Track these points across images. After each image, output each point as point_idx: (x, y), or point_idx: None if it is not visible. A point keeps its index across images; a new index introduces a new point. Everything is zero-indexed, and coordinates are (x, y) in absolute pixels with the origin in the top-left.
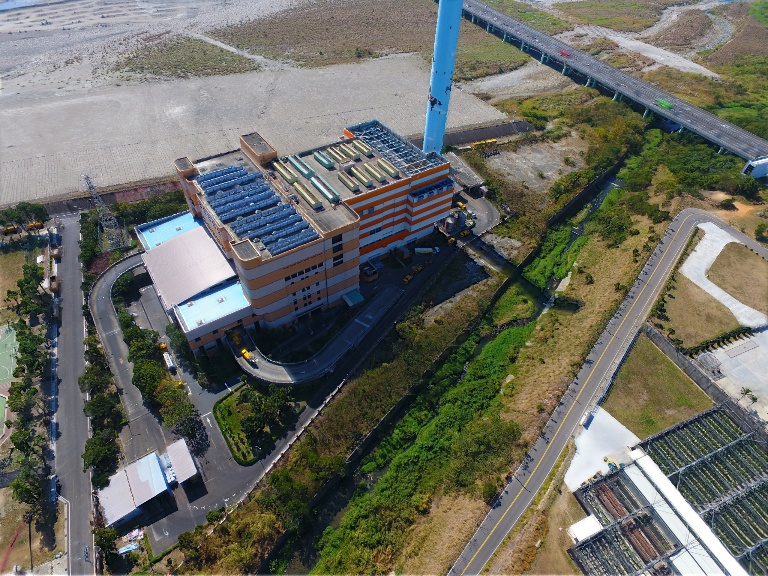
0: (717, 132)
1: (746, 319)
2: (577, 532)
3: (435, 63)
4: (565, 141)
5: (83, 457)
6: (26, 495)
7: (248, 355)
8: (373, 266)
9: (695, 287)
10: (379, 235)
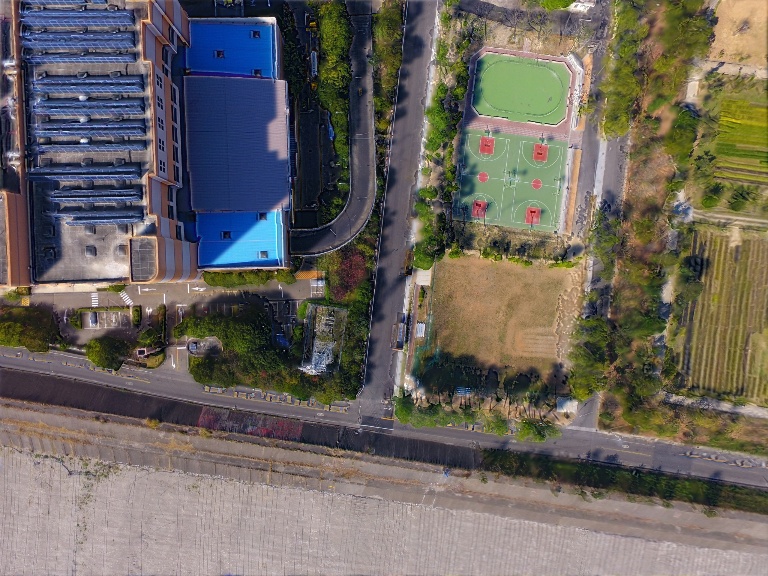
0: None
1: None
2: None
3: None
4: None
5: None
6: None
7: None
8: None
9: None
10: None
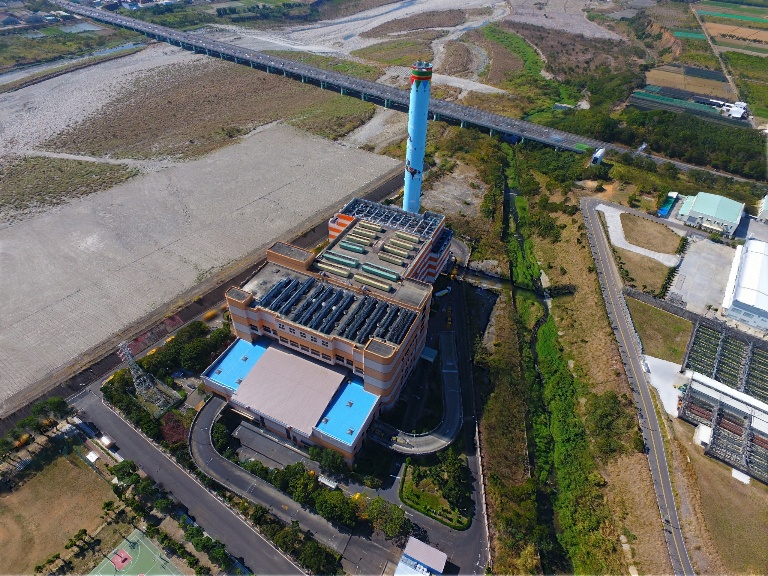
0: (547, 136)
1: (667, 262)
2: (703, 439)
3: (413, 142)
4: (458, 170)
5: None
6: None
7: (401, 440)
8: None
9: (629, 252)
10: None
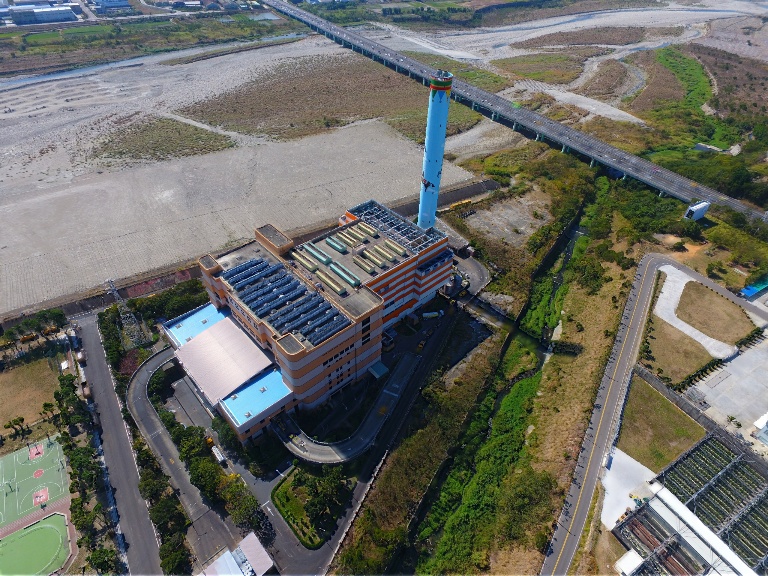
0: (655, 178)
1: (716, 351)
2: (623, 567)
3: (427, 153)
4: (530, 195)
5: (162, 566)
6: None
7: (296, 440)
8: (389, 336)
9: (669, 326)
10: (392, 307)
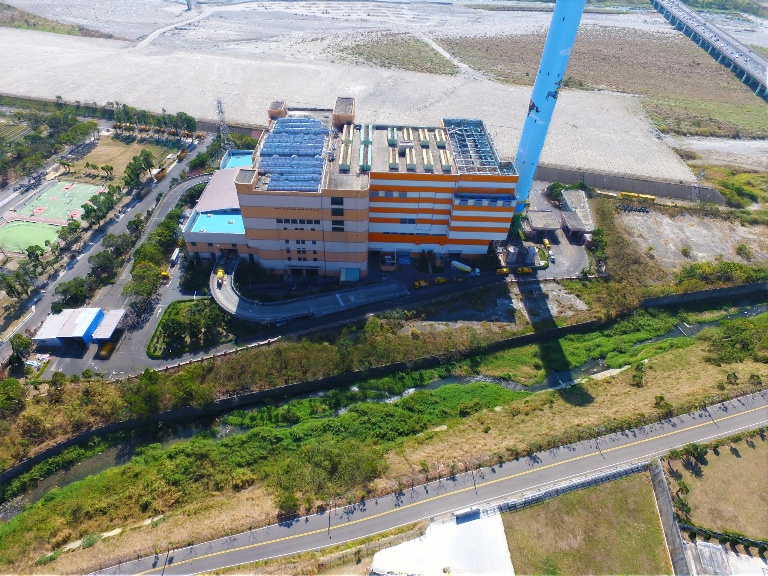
0: None
1: None
2: None
3: (541, 61)
4: (761, 229)
5: (59, 285)
6: (8, 287)
7: (220, 274)
8: (395, 257)
9: None
10: (412, 228)
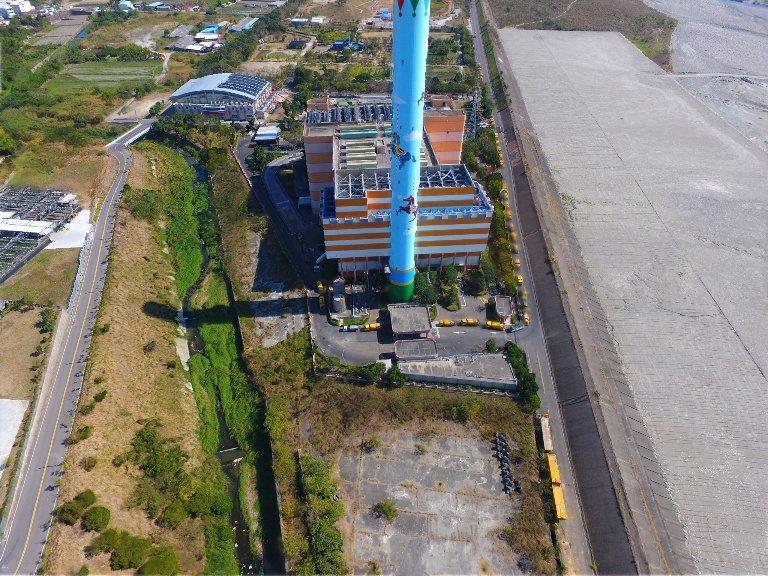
0: None
1: None
2: (72, 195)
3: None
4: None
5: None
6: None
7: (297, 153)
8: None
9: (2, 392)
10: None
